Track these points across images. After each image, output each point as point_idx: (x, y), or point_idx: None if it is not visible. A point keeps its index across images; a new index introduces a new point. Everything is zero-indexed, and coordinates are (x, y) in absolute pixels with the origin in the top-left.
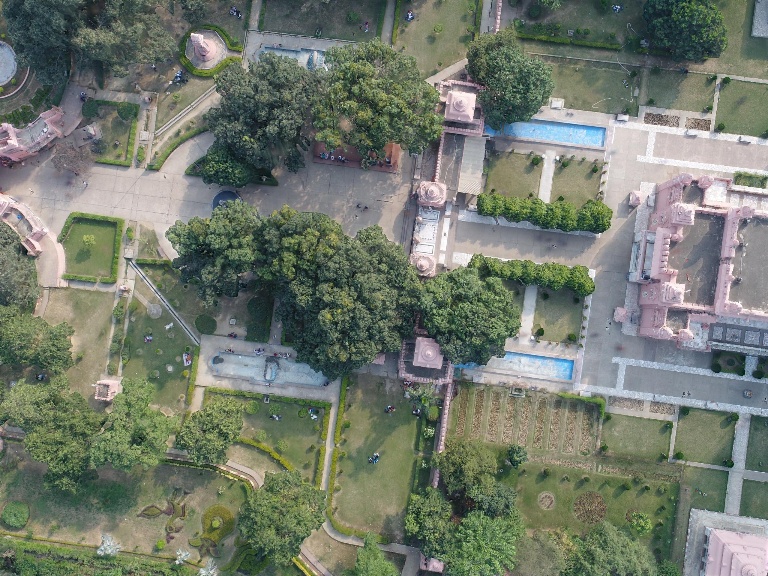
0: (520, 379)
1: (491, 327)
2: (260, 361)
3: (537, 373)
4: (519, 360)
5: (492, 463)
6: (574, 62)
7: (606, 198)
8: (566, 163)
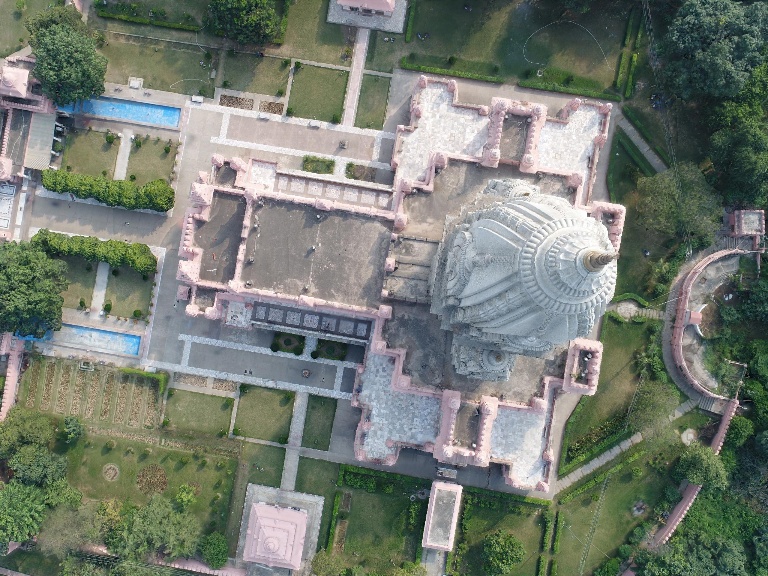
0: (89, 353)
1: (9, 299)
2: None
3: (106, 348)
4: (90, 334)
5: (40, 433)
6: (155, 42)
7: (179, 178)
8: (138, 142)
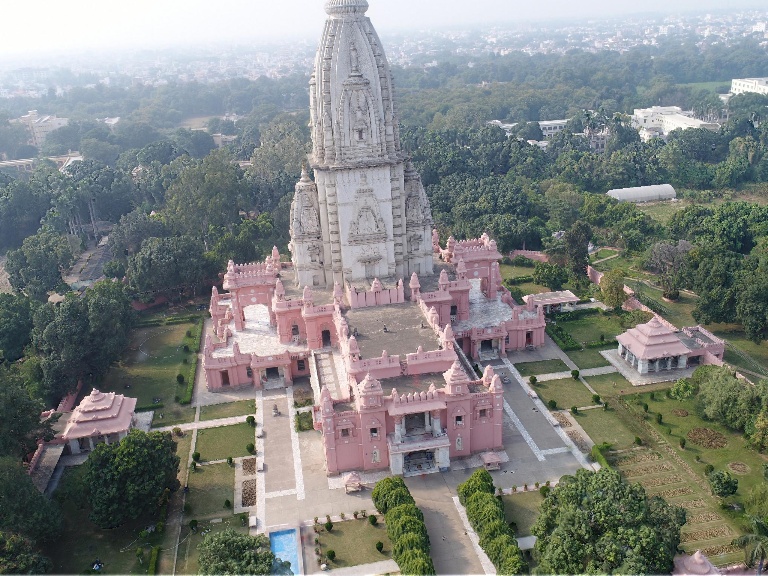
0: None
1: None
2: None
3: None
4: None
5: None
6: None
7: None
8: (330, 552)
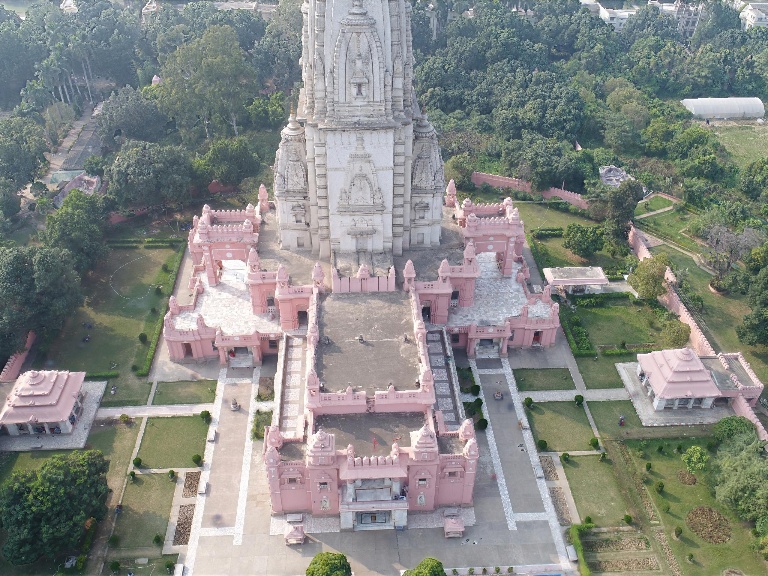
0: None
1: None
2: None
3: None
4: None
5: None
6: None
7: (297, 575)
8: None
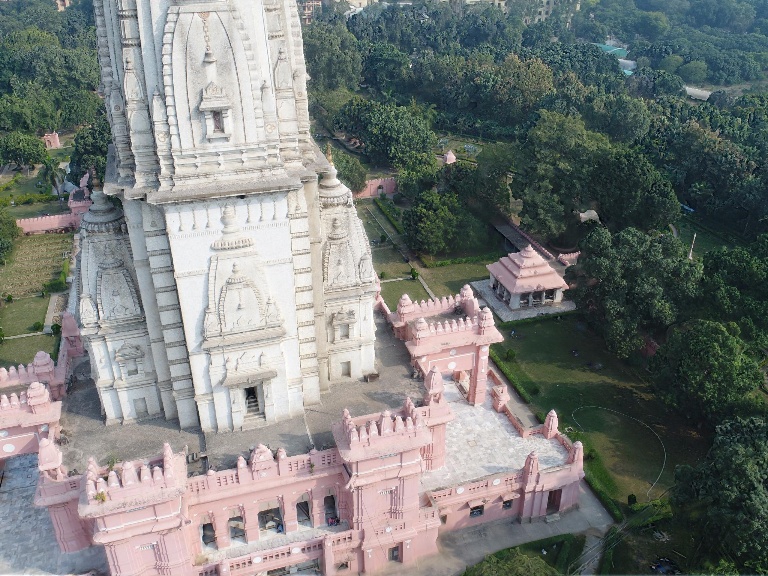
0: None
1: None
2: None
3: None
4: None
5: None
6: None
7: None
8: None
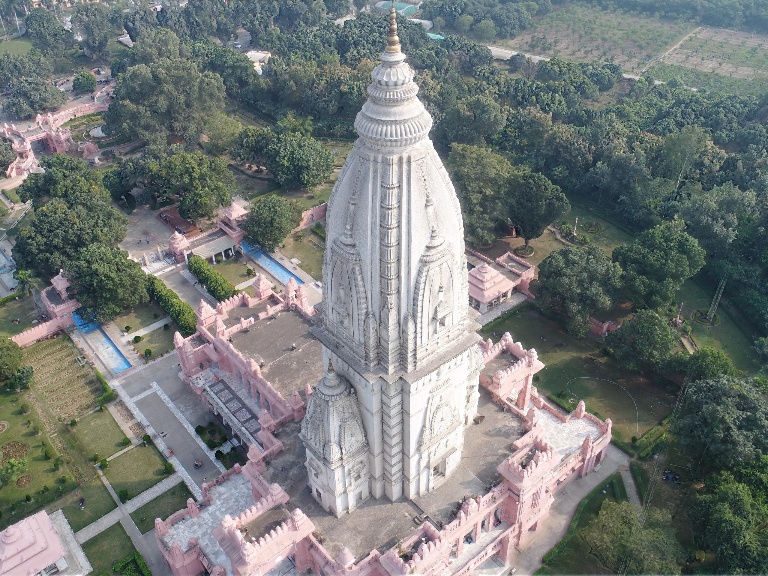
0: (93, 354)
1: (99, 264)
2: (8, 264)
3: (106, 359)
4: (108, 347)
5: (6, 357)
6: None
7: None
8: None
